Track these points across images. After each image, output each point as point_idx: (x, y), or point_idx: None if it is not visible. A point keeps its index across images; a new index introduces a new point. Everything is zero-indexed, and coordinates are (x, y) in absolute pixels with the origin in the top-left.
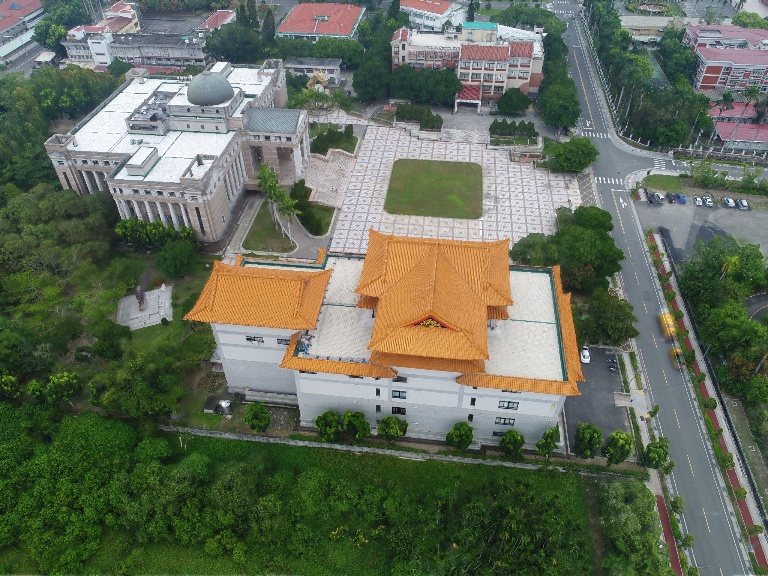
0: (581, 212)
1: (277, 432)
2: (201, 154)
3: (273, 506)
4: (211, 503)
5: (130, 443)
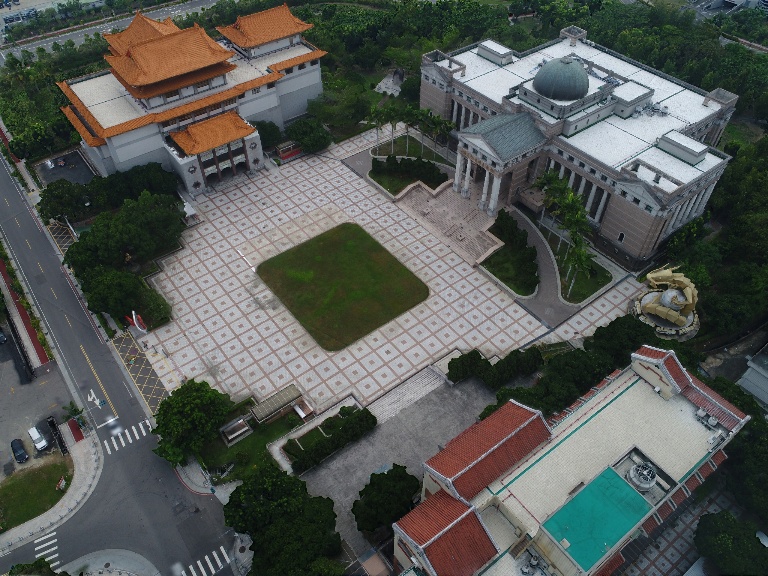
0: None
1: None
2: (463, 66)
3: None
4: None
5: None
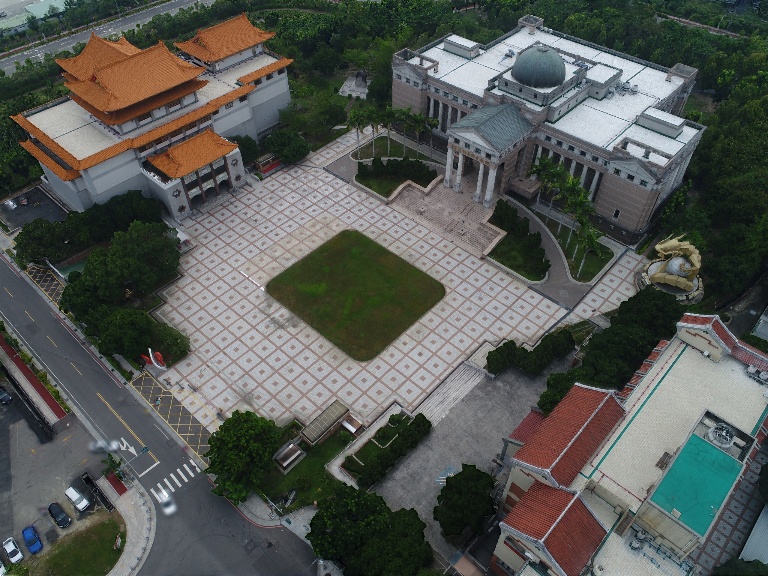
0: None
1: None
2: (436, 62)
3: None
4: None
5: None
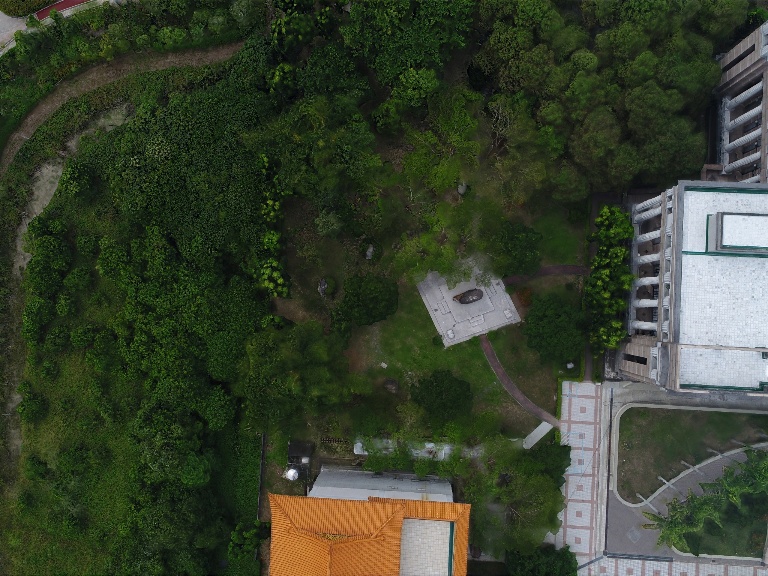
0: None
1: (268, 539)
2: None
3: (150, 572)
4: (162, 494)
5: (225, 379)
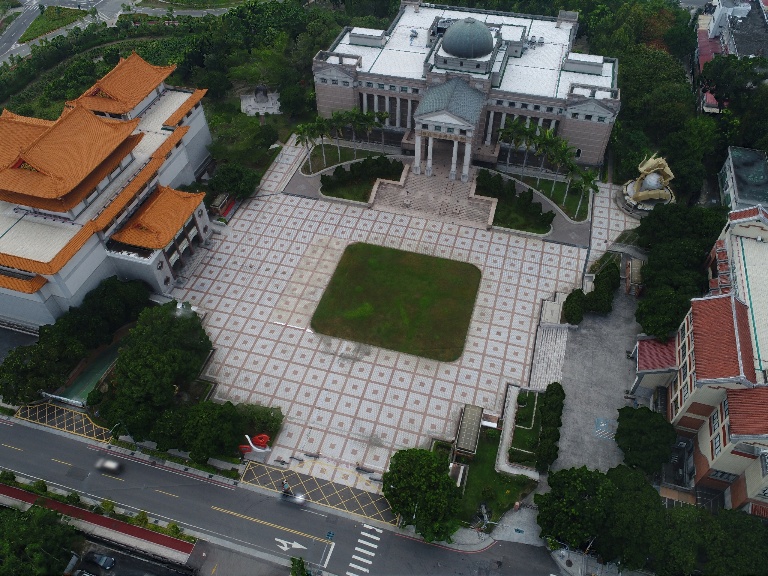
0: (220, 406)
1: None
2: (360, 57)
3: None
4: None
5: None
